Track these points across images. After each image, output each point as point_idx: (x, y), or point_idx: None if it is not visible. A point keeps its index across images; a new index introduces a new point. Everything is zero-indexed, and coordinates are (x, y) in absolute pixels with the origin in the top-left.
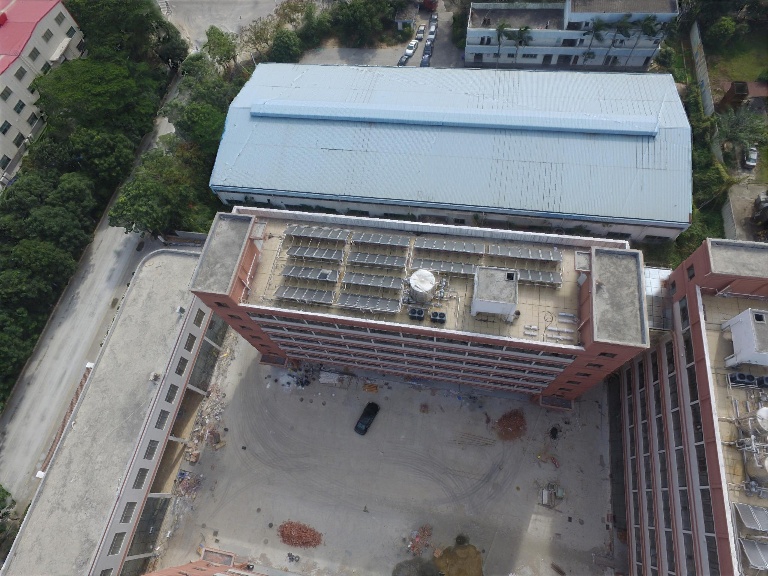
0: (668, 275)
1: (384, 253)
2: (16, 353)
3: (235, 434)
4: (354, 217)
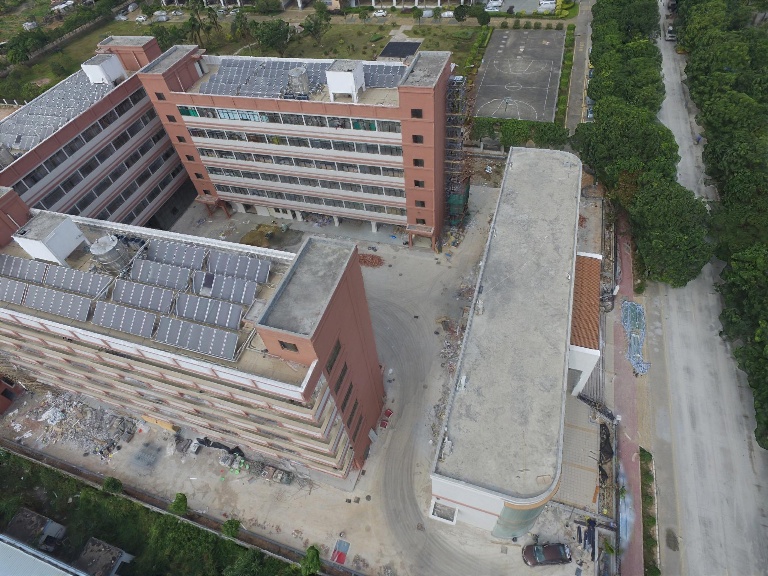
0: None
1: None
2: (762, 413)
3: (427, 329)
4: (136, 345)
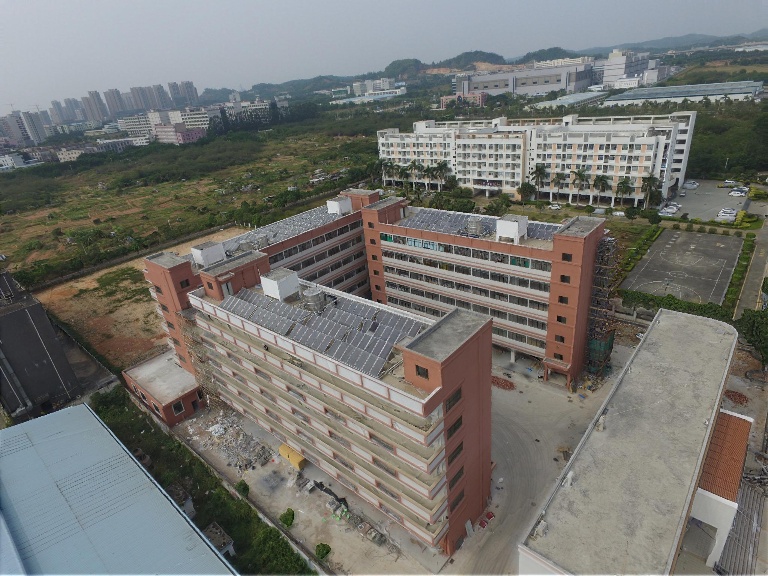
0: (182, 310)
1: None
2: None
3: (546, 454)
4: (314, 351)
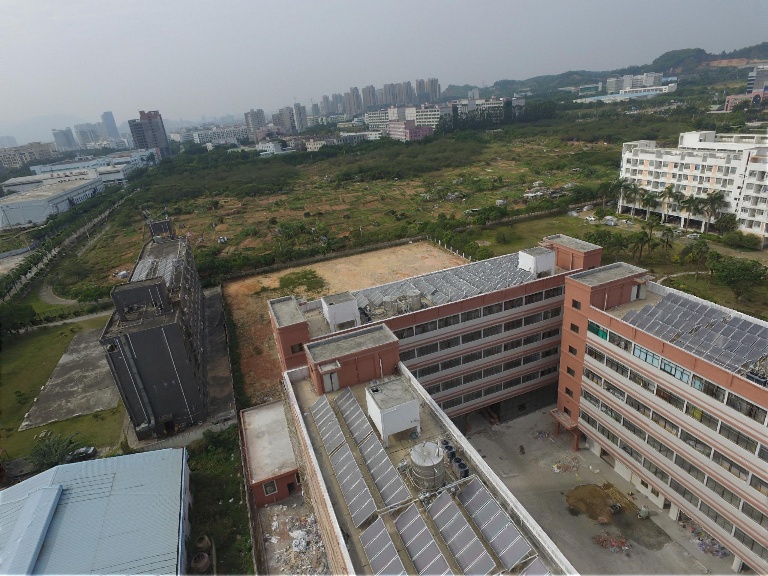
0: None
1: (403, 560)
2: None
3: None
4: None
